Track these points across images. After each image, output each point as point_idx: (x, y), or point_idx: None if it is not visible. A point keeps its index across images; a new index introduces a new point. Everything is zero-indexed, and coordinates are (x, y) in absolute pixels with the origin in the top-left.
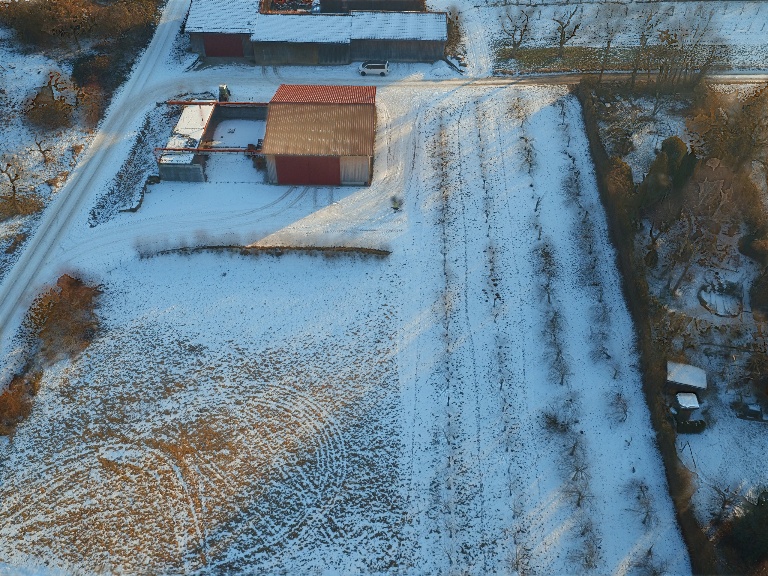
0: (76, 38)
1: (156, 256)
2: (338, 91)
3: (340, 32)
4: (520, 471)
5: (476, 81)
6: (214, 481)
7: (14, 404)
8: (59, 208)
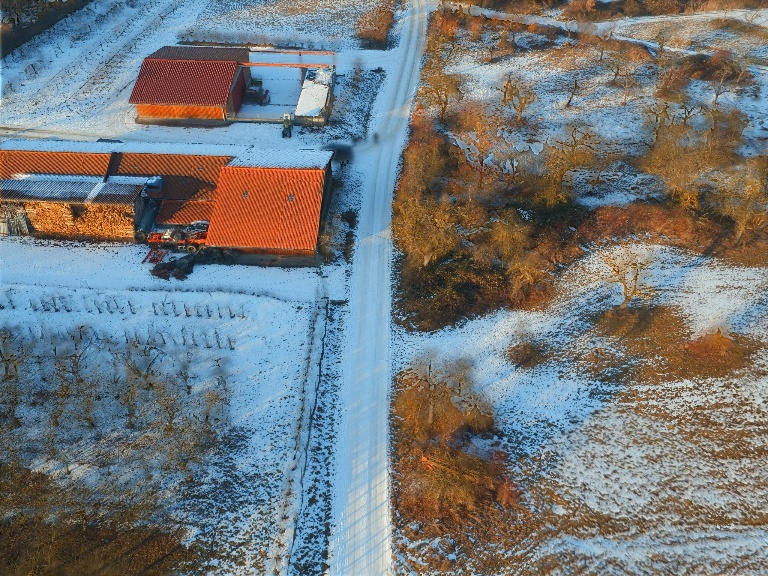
0: (481, 175)
1: (329, 50)
2: (170, 87)
3: (137, 146)
4: (158, 0)
5: (10, 133)
6: (287, 3)
7: (383, 16)
8: (411, 79)
